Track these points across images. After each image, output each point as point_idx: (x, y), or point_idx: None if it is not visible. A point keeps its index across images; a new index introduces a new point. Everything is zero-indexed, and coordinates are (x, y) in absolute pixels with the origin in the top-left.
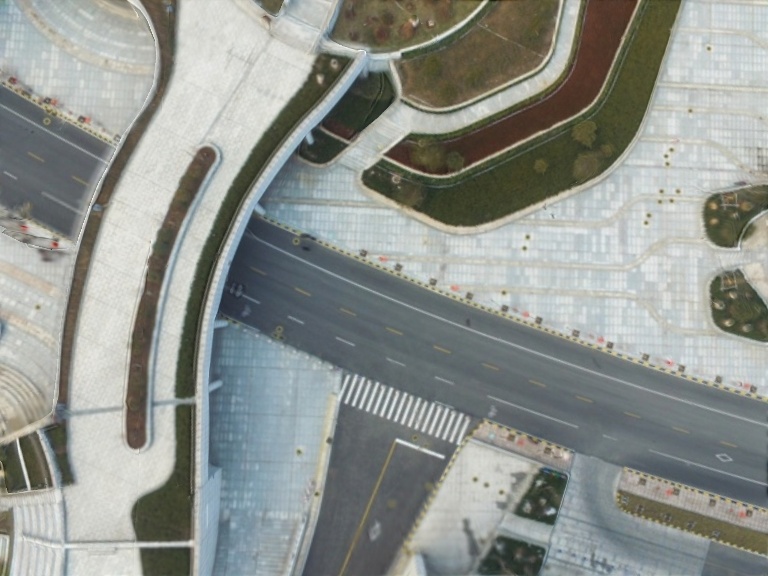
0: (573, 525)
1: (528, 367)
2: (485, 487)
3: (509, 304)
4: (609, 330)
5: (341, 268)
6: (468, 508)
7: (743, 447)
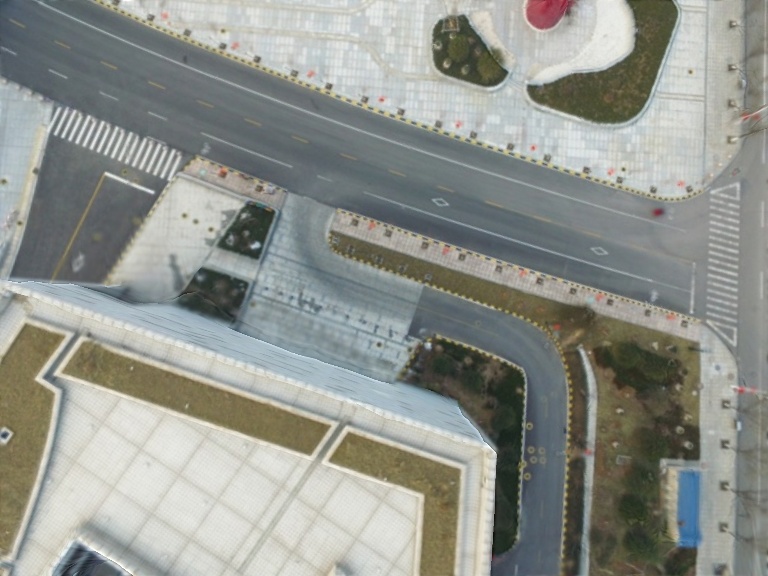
0: (281, 263)
1: (244, 106)
2: (194, 223)
3: (227, 42)
4: (329, 71)
5: (58, 1)
6: (175, 243)
7: (460, 192)
